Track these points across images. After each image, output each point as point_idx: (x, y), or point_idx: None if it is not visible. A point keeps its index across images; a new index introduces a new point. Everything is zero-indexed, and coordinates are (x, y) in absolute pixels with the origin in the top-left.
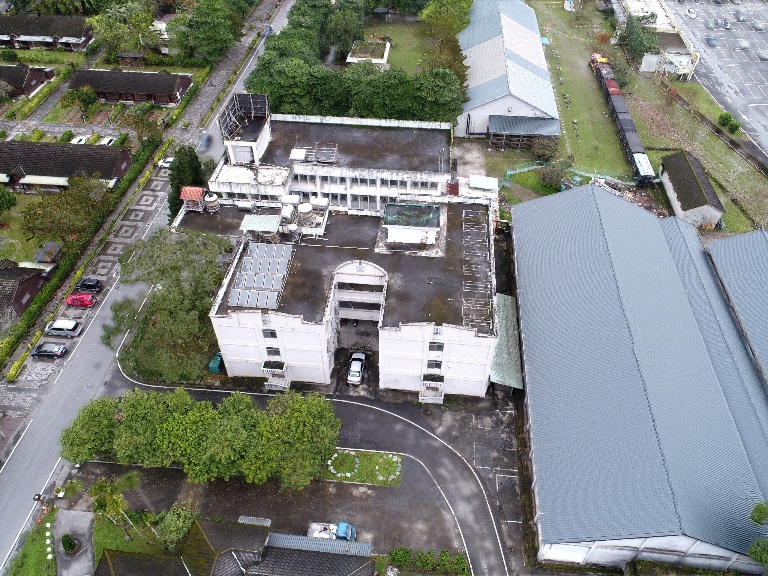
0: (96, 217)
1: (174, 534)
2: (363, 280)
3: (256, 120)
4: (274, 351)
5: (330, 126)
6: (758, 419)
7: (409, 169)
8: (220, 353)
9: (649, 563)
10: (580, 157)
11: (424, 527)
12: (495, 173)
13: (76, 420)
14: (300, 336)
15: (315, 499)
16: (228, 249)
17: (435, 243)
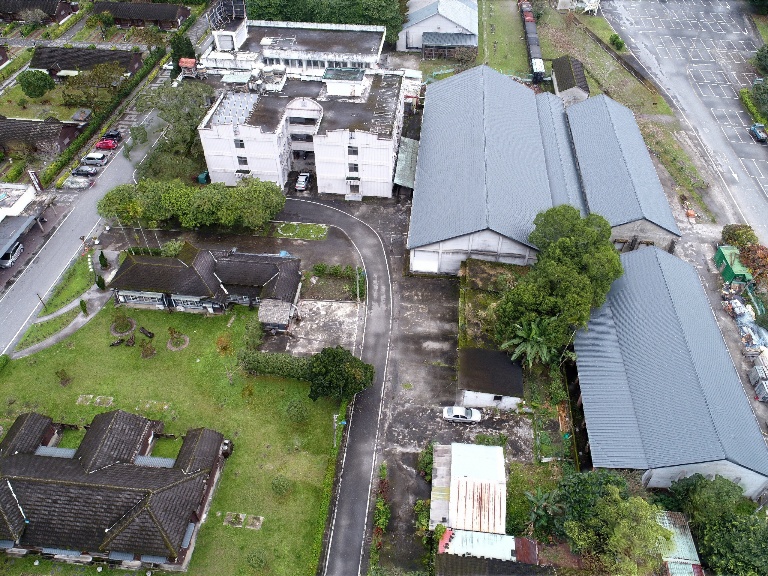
0: (116, 97)
1: (172, 252)
2: (306, 114)
3: (236, 20)
4: (243, 161)
5: (294, 29)
6: (567, 195)
7: None
8: (206, 171)
9: (474, 259)
10: (494, 65)
11: (339, 259)
12: (425, 74)
13: (107, 193)
14: (260, 145)
15: (268, 246)
16: (213, 101)
17: (361, 96)
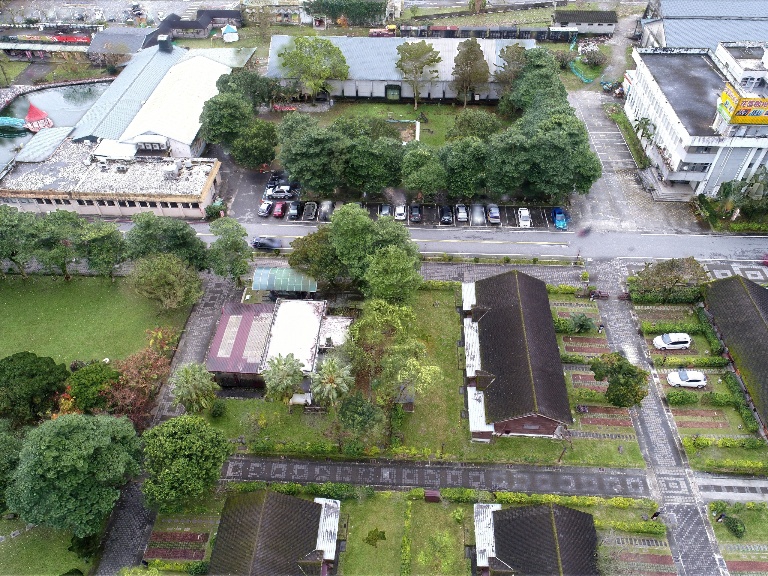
0: None
1: None
2: None
3: None
4: None
5: None
6: None
7: (706, 67)
8: None
9: None
10: None
11: None
12: (584, 87)
13: None
14: None
15: None
16: None
17: None
